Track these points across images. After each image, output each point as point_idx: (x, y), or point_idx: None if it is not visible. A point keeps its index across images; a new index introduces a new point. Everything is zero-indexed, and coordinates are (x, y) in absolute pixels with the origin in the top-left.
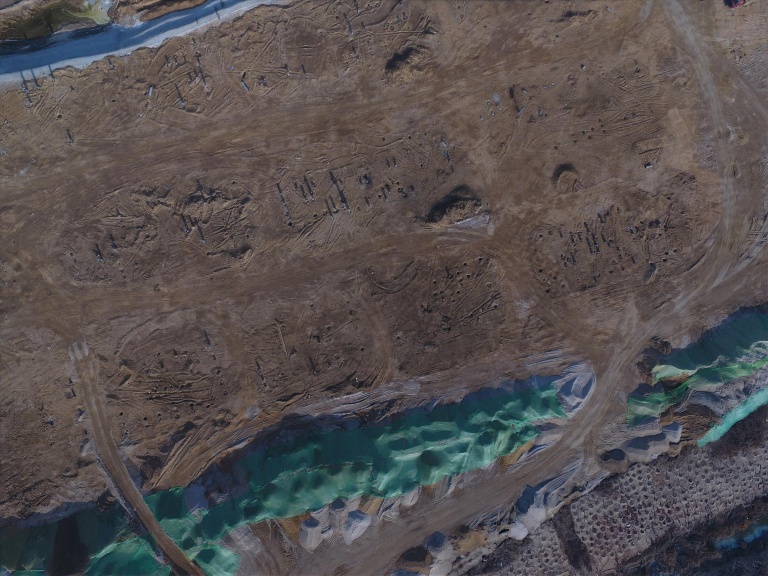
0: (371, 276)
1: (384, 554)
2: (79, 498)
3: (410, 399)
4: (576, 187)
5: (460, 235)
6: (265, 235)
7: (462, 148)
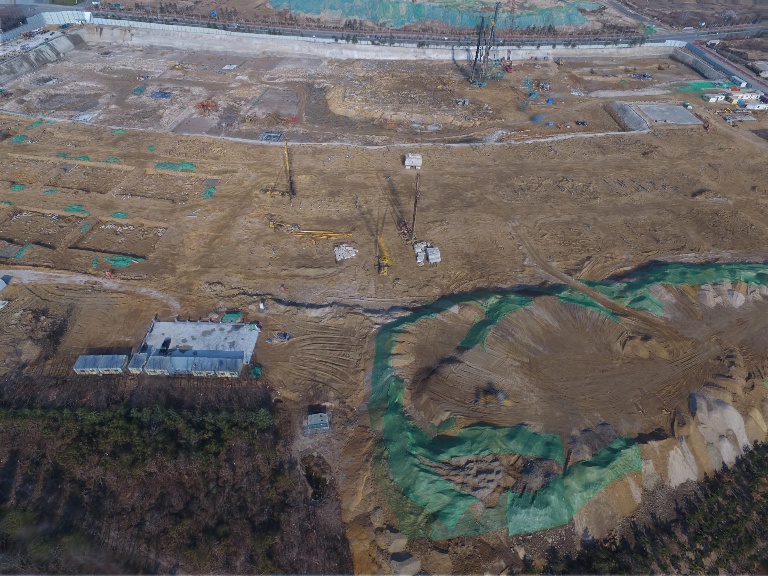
0: (673, 212)
1: (766, 317)
2: (526, 283)
3: (728, 259)
4: (767, 193)
5: (714, 203)
6: (605, 195)
7: (695, 178)
